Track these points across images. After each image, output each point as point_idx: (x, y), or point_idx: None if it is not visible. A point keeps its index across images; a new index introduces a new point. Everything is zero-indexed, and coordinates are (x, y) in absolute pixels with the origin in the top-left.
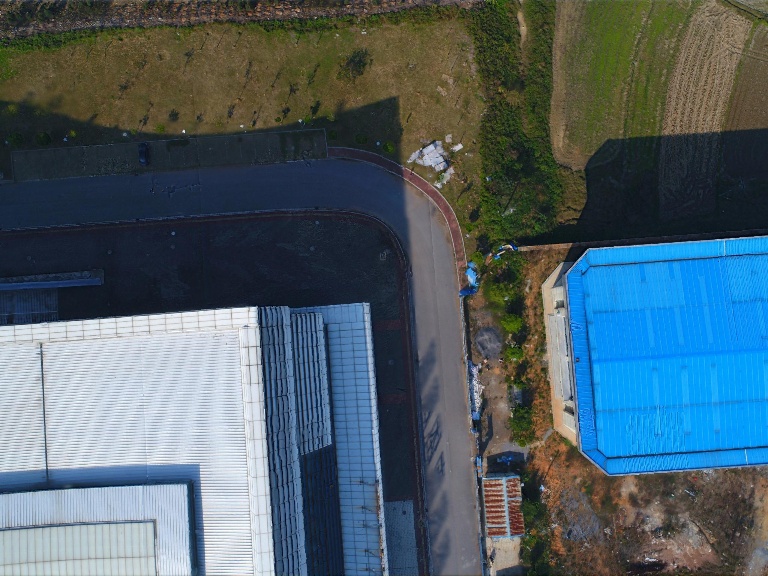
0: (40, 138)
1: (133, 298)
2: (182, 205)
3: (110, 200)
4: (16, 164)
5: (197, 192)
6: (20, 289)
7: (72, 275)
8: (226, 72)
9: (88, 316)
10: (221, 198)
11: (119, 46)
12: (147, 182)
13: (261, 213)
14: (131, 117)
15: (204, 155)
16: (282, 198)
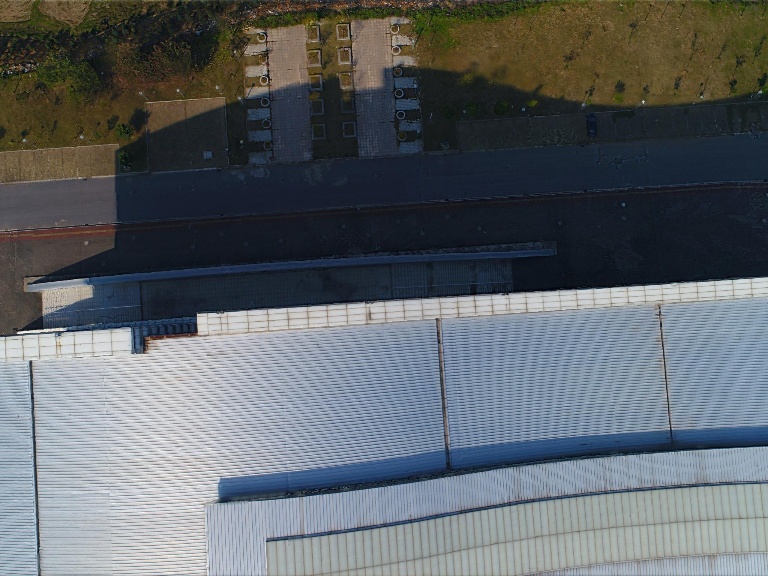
0: (504, 107)
1: (587, 269)
2: (630, 176)
3: (557, 171)
4: (461, 134)
5: (644, 163)
6: (485, 258)
7: (524, 246)
8: (671, 43)
9: (542, 287)
10: (669, 170)
11: (562, 17)
12: (593, 153)
13: (711, 185)
14: (577, 88)
15: (650, 127)
16: (730, 170)
